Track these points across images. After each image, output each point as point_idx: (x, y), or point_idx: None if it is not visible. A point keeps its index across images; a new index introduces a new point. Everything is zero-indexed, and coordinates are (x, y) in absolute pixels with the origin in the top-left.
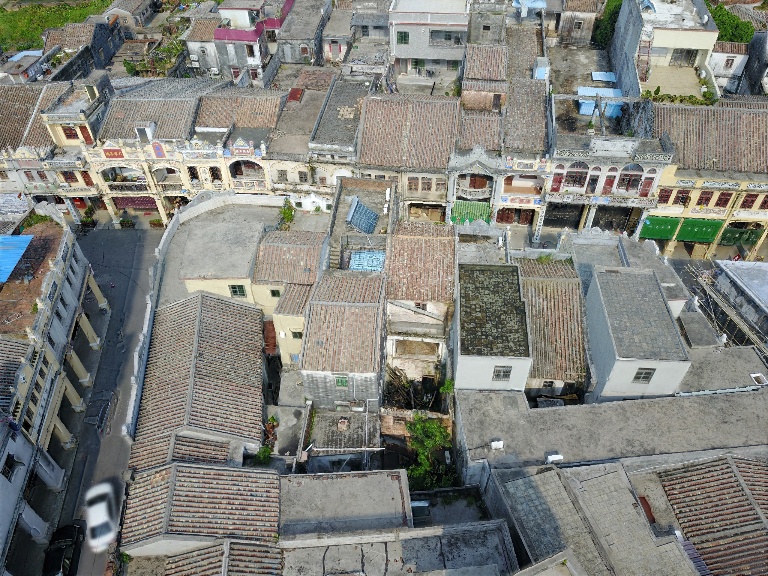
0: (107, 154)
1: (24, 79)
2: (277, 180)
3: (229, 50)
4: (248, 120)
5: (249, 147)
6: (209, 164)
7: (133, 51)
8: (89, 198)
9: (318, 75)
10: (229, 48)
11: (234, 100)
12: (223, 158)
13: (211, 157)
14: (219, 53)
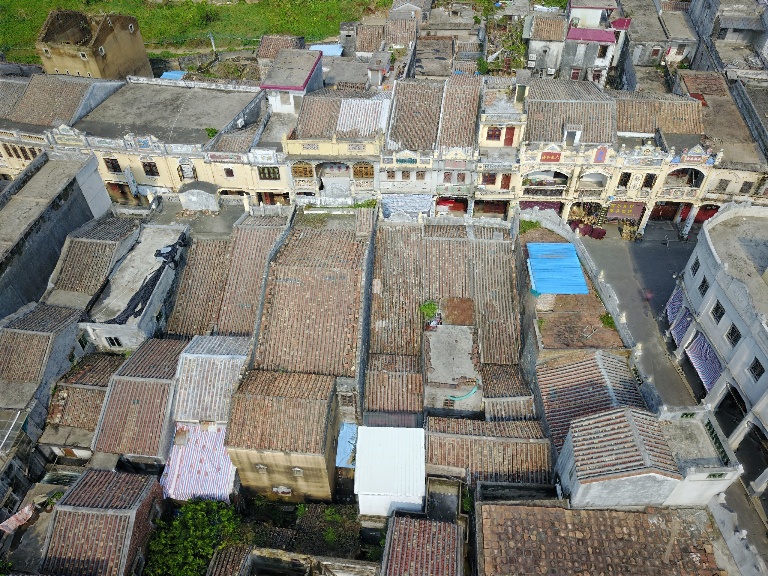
0: (543, 157)
1: (380, 75)
2: (713, 190)
3: (579, 50)
4: (672, 125)
5: (705, 155)
6: (648, 171)
7: (432, 48)
8: (475, 200)
9: (704, 79)
10: (580, 48)
11: (651, 104)
12: (668, 165)
13: (654, 164)
14: (566, 53)
